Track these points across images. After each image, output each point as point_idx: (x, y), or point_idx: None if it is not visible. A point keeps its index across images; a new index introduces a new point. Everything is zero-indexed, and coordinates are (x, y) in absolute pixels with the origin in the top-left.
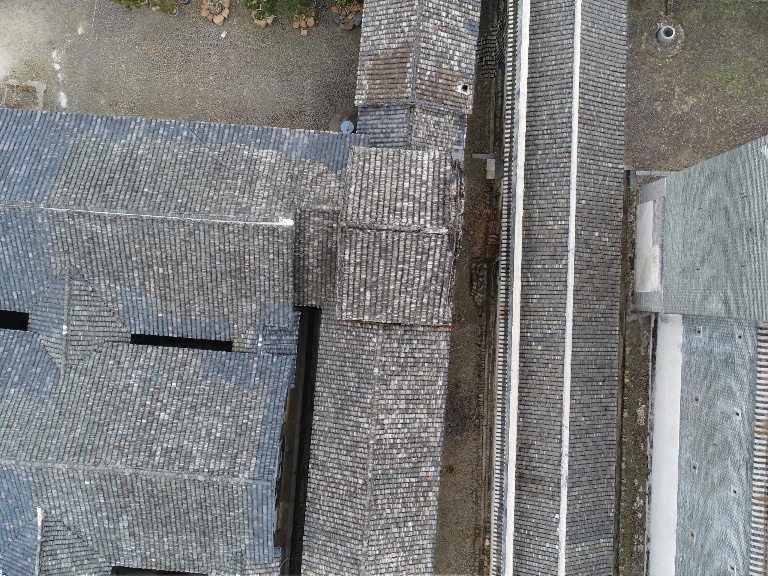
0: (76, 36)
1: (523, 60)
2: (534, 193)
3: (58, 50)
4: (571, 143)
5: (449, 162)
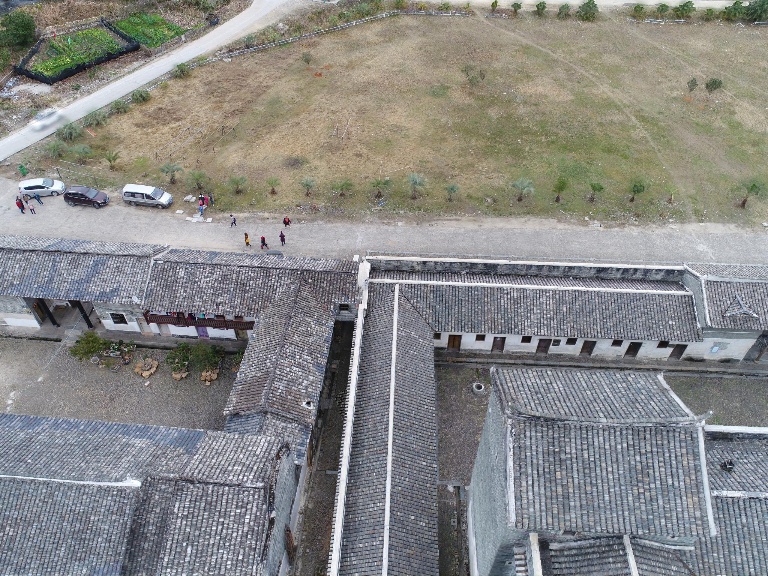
0: (35, 382)
1: (352, 385)
2: (360, 483)
3: (17, 391)
4: (388, 442)
5: (280, 443)
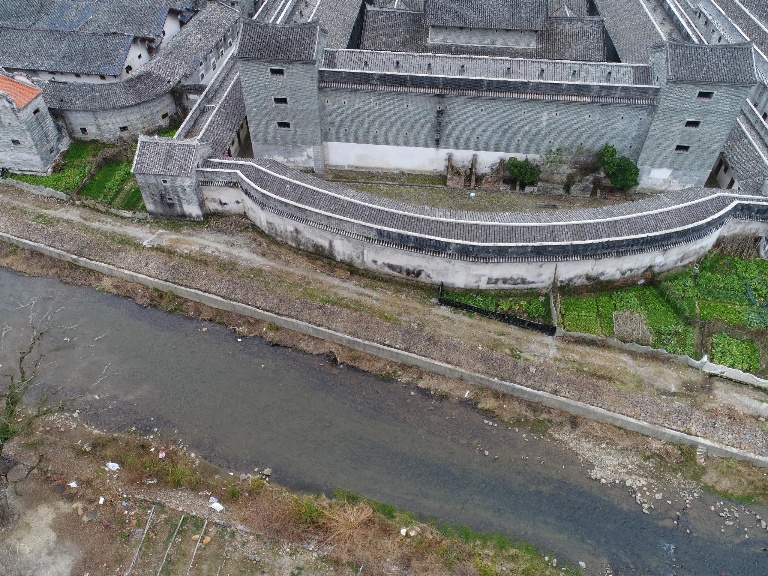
0: None
1: None
2: None
3: None
4: None
5: None
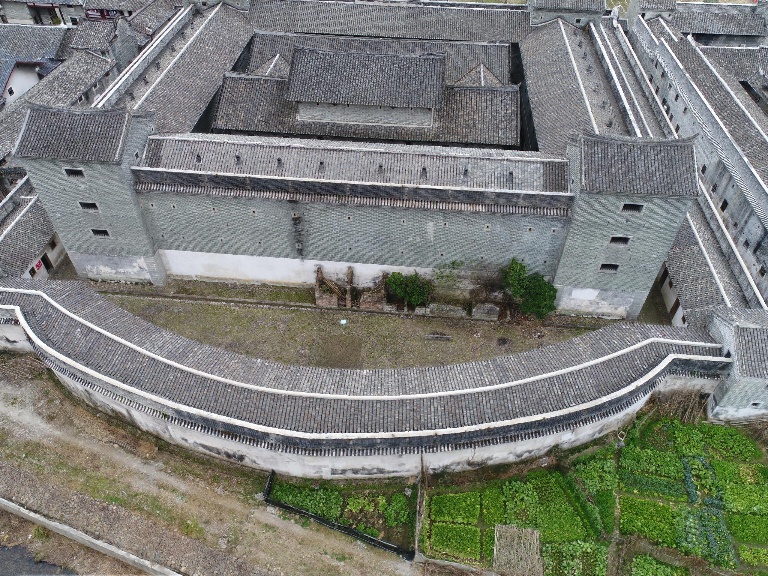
0: None
1: None
2: None
3: None
4: None
5: None
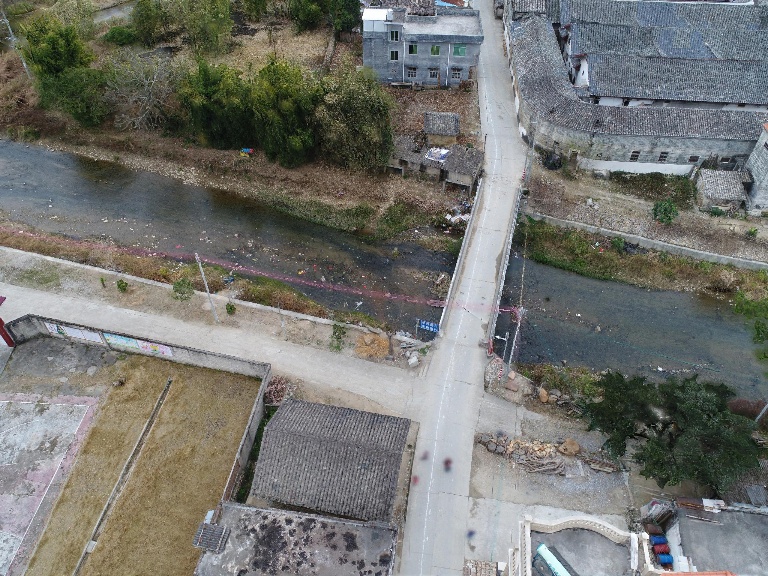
0: None
1: None
2: None
3: None
4: None
5: None
